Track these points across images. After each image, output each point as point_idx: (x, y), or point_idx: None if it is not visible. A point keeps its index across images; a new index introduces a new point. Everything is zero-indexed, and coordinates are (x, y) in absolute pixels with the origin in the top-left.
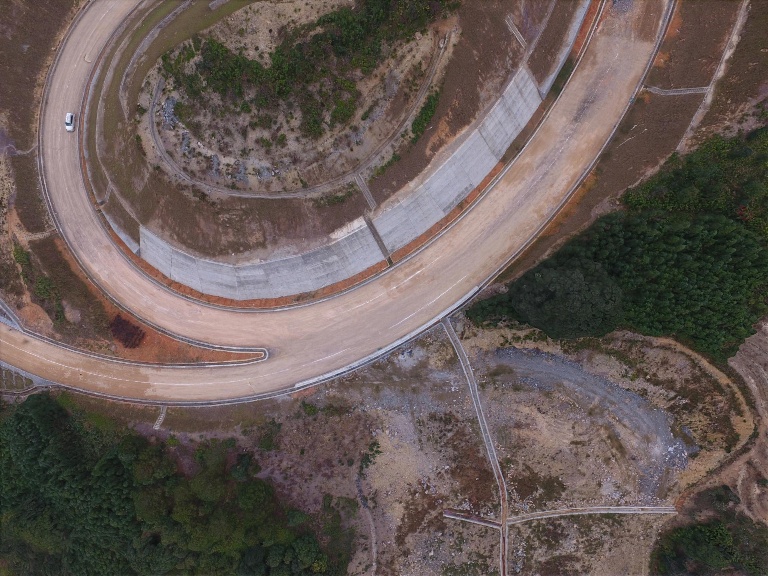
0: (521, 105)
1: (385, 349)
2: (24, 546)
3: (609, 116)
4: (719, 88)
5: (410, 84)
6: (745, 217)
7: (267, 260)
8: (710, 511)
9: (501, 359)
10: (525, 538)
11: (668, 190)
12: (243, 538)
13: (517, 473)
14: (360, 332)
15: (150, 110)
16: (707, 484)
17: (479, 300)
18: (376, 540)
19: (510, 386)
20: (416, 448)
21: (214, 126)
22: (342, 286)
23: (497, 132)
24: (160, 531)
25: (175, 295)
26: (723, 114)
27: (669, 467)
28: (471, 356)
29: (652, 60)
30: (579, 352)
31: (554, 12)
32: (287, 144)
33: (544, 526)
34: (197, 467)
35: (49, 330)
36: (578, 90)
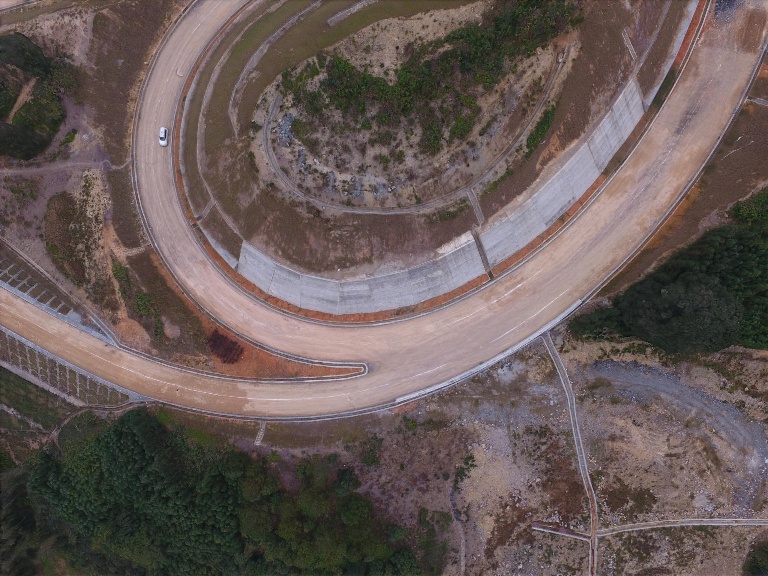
0: (626, 117)
1: (487, 363)
2: (104, 559)
3: (712, 128)
4: None
5: (528, 99)
6: None
7: (373, 275)
8: None
9: (599, 372)
10: (615, 550)
11: None
12: (345, 554)
13: (607, 485)
14: (461, 346)
15: (265, 127)
16: None
17: (581, 313)
18: (465, 553)
19: (608, 399)
20: (510, 461)
21: (332, 143)
22: (442, 300)
23: (603, 145)
24: (265, 548)
25: (272, 310)
26: None
27: (765, 479)
28: (570, 369)
29: (756, 71)
30: (677, 364)
31: (664, 24)
32: (404, 160)
33: (635, 538)
34: (298, 483)
35: (145, 346)
36: (680, 102)
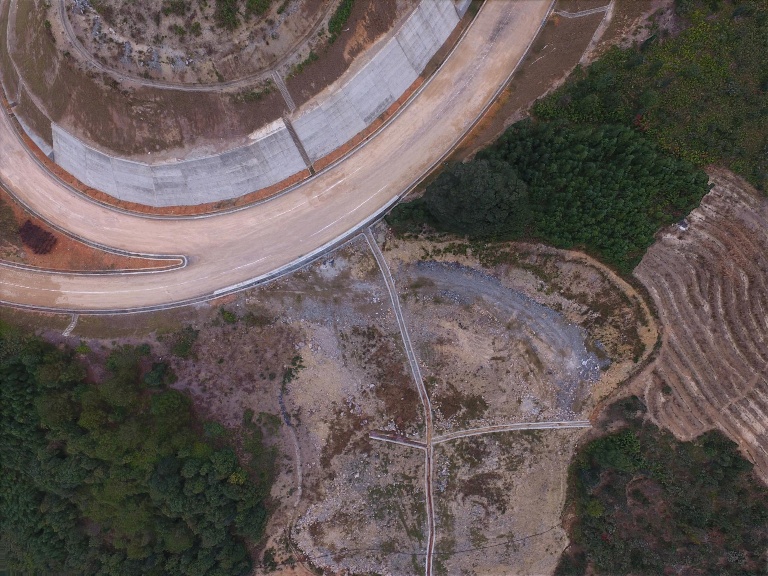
0: (438, 20)
1: (306, 256)
2: None
3: (522, 37)
4: (618, 7)
5: None
6: (642, 128)
7: (184, 159)
8: (621, 422)
9: (422, 272)
10: (449, 457)
11: (573, 101)
12: (157, 449)
13: (441, 392)
14: (281, 240)
15: None
16: (618, 396)
17: None
18: (301, 462)
19: (431, 298)
20: (340, 364)
21: (126, 10)
22: (264, 194)
23: (415, 44)
24: (66, 439)
25: (91, 202)
26: (620, 29)
27: (583, 381)
28: (393, 268)
29: None
30: (497, 266)
31: None
32: (201, 33)
33: (467, 444)
34: (109, 376)
35: None
36: (494, 12)
